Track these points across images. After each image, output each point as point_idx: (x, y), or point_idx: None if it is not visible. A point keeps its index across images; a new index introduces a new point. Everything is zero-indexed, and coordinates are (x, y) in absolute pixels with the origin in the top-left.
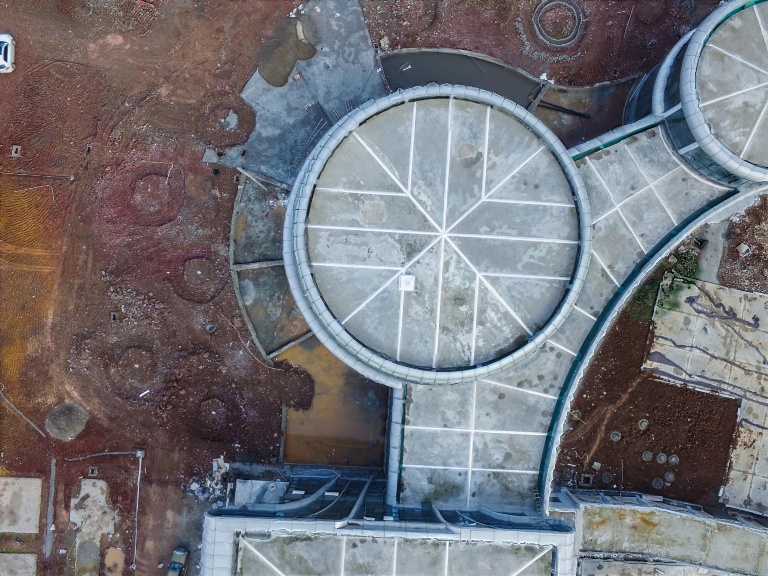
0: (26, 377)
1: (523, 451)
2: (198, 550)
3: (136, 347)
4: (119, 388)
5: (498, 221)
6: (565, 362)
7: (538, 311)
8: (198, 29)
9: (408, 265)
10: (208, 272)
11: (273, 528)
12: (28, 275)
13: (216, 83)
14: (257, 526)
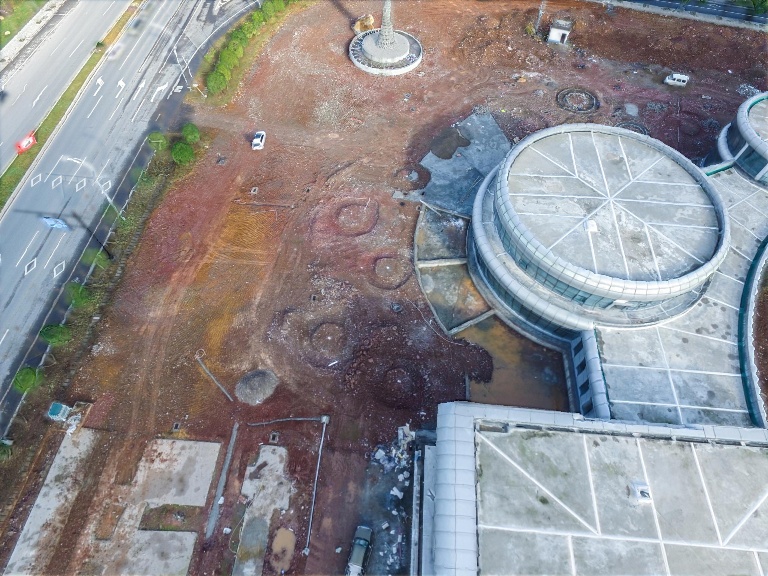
0: (226, 346)
1: (724, 390)
2: (382, 531)
3: (330, 323)
4: (310, 358)
5: (648, 193)
6: (731, 315)
7: (702, 248)
8: (390, 132)
9: (589, 216)
10: (395, 268)
11: (512, 416)
12: (246, 267)
13: (402, 157)
14: (496, 413)
